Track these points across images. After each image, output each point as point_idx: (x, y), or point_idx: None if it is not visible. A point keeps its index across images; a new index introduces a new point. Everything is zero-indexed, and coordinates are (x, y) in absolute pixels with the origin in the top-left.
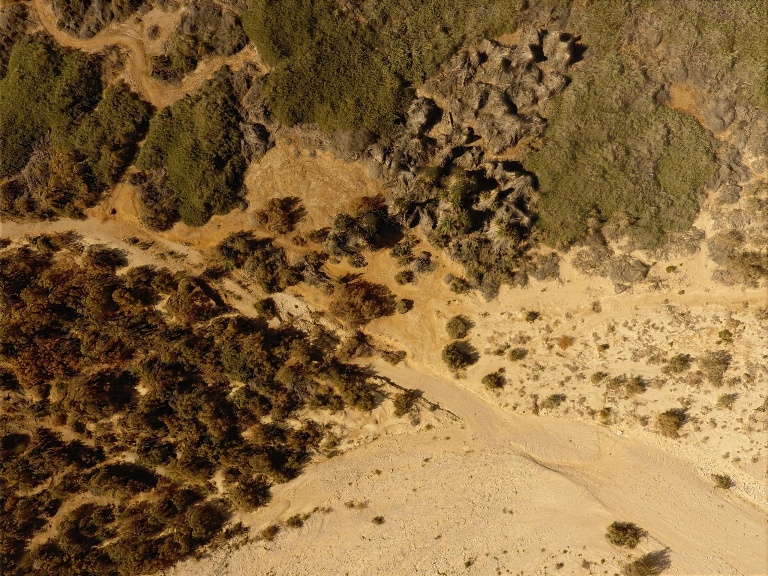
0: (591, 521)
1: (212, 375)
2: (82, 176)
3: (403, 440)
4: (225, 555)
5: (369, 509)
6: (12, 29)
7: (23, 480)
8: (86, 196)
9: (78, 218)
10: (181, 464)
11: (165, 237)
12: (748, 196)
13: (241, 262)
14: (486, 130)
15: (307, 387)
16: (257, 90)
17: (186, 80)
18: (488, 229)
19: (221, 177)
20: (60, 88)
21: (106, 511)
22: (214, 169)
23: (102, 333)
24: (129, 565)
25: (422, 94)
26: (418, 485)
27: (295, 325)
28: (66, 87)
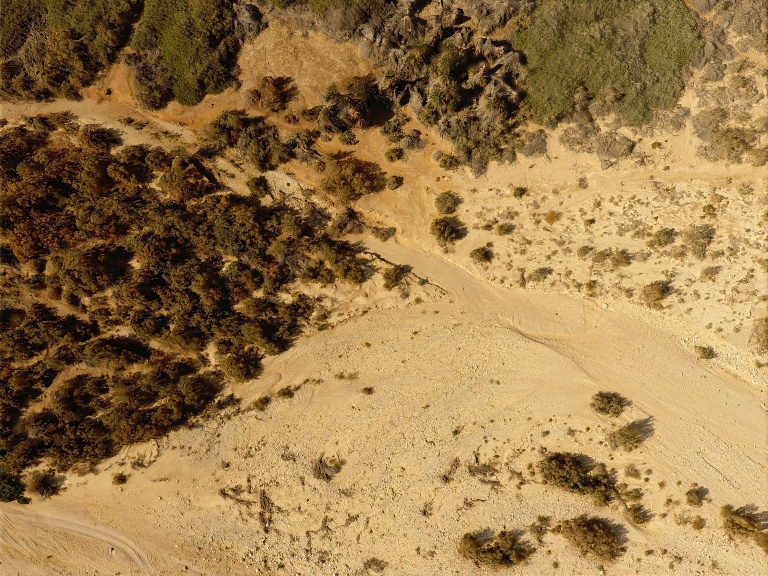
0: (576, 391)
1: (205, 250)
2: (78, 53)
3: (392, 314)
4: (217, 425)
5: (359, 380)
6: None
7: (18, 348)
8: (82, 74)
9: (74, 99)
10: (174, 332)
11: (159, 117)
12: (732, 74)
13: (234, 141)
14: (475, 10)
15: (298, 261)
16: None
17: None
18: (477, 106)
19: (215, 54)
20: None
21: (100, 381)
22: (208, 46)
23: (97, 207)
24: (122, 430)
25: None
26: (407, 357)
27: (287, 202)
28: None
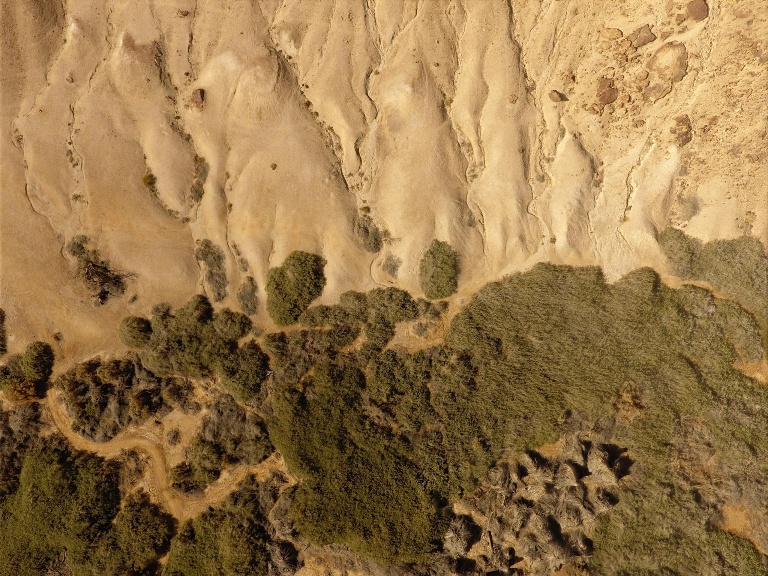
0: None
1: None
2: None
3: None
4: None
5: None
6: (24, 432)
7: None
8: None
9: None
10: None
11: None
12: None
13: None
14: (529, 557)
15: None
16: (284, 505)
17: (209, 490)
18: None
19: None
20: (76, 512)
21: None
22: None
23: None
24: None
25: (459, 509)
26: None
27: None
28: (82, 511)
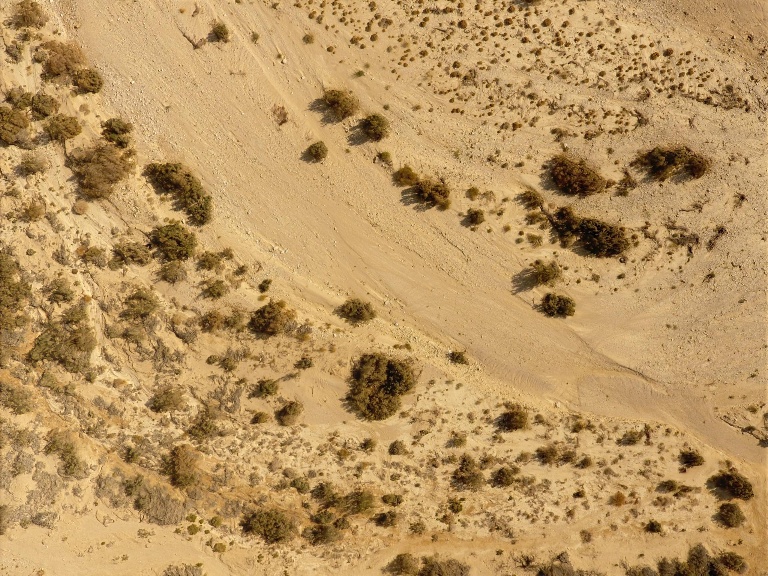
0: (589, 319)
1: None
2: None
3: None
4: None
5: None
6: None
7: None
8: None
9: None
10: None
11: None
12: None
13: None
14: None
15: None
16: None
17: None
18: None
19: None
20: None
21: None
22: None
23: None
24: None
25: None
26: (762, 352)
27: None
28: None
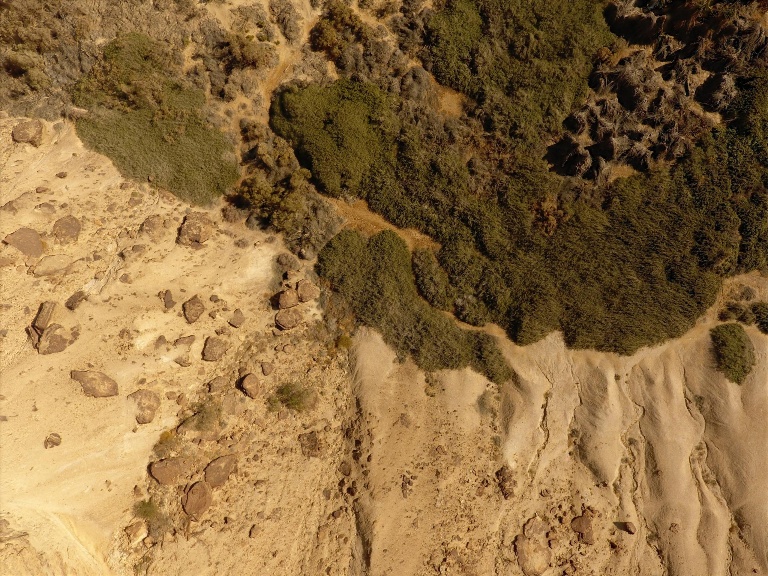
0: None
1: None
2: None
3: None
4: None
5: None
6: None
7: None
8: None
9: None
10: None
11: None
12: (395, 1)
13: None
14: None
15: None
16: None
17: None
18: None
19: None
20: None
21: None
22: None
23: None
24: None
25: (714, 118)
26: None
27: None
28: None
